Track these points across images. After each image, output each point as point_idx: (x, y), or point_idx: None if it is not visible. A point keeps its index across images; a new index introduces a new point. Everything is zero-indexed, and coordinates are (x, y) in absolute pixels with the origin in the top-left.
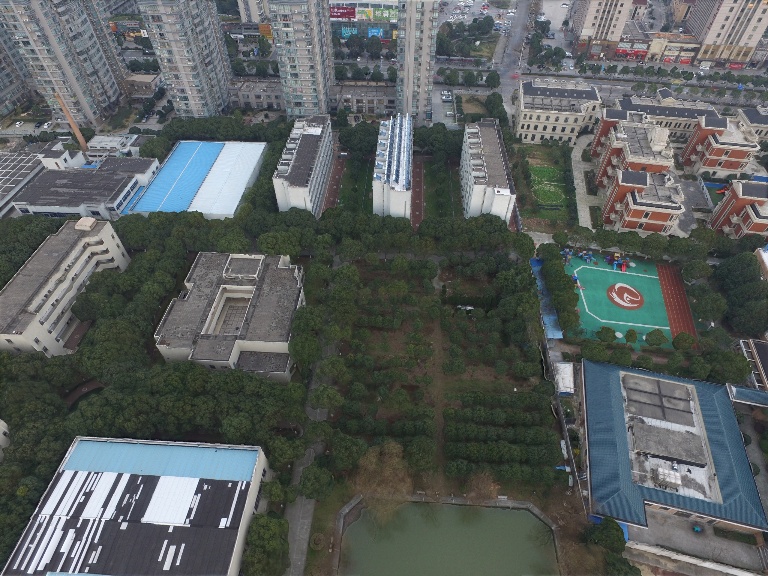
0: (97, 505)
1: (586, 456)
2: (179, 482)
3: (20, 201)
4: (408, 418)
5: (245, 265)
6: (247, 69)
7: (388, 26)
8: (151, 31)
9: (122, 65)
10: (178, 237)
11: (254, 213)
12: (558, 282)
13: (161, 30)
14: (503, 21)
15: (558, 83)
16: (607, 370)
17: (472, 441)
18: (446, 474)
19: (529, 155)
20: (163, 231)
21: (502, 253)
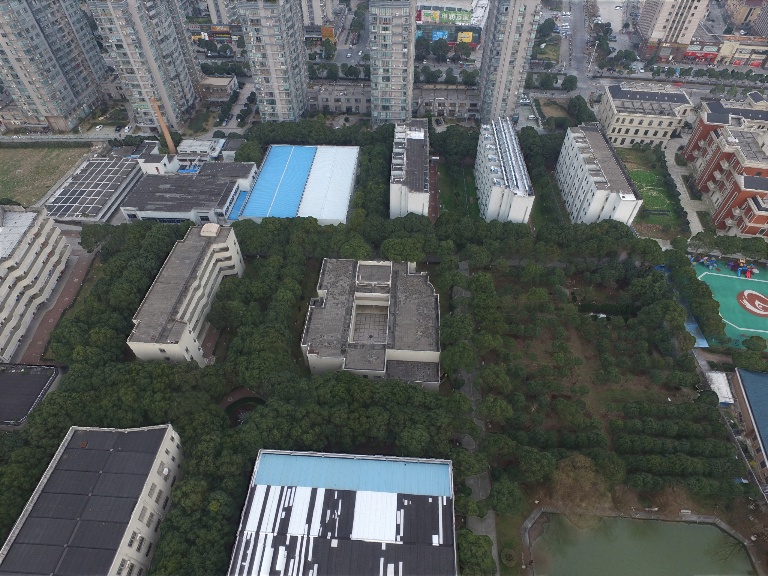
0: (301, 521)
1: (764, 469)
2: (377, 497)
3: (128, 206)
4: (568, 429)
5: (374, 272)
6: (317, 72)
7: (454, 29)
8: (248, 34)
9: (198, 68)
10: (298, 243)
11: (371, 219)
12: (696, 289)
13: (258, 33)
14: (560, 23)
15: (647, 86)
16: (767, 380)
17: (649, 453)
18: None
19: (622, 159)
20: (281, 237)
21: (629, 259)
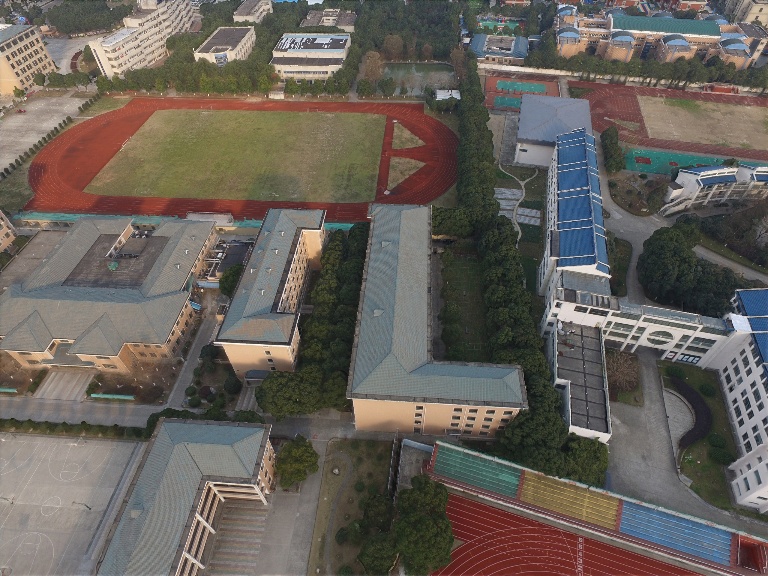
0: None
1: None
2: None
3: None
4: None
5: None
6: None
7: None
8: None
9: None
10: (299, 7)
11: None
12: None
13: None
14: None
15: None
16: None
17: None
18: (416, 57)
19: None
20: None
21: None
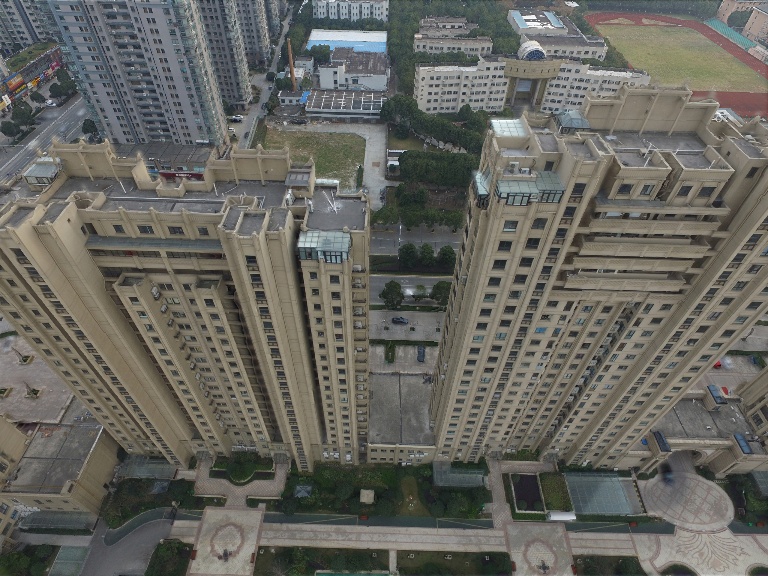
0: None
1: None
2: (524, 17)
3: (383, 74)
4: None
5: None
6: None
7: None
8: None
9: None
10: None
11: (393, 20)
12: None
13: None
14: None
15: None
16: None
17: None
18: None
19: None
20: (407, 38)
21: None
